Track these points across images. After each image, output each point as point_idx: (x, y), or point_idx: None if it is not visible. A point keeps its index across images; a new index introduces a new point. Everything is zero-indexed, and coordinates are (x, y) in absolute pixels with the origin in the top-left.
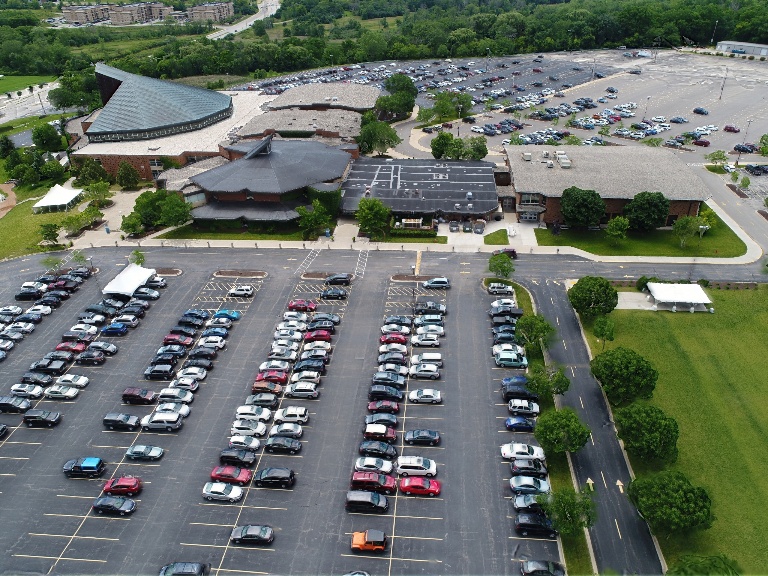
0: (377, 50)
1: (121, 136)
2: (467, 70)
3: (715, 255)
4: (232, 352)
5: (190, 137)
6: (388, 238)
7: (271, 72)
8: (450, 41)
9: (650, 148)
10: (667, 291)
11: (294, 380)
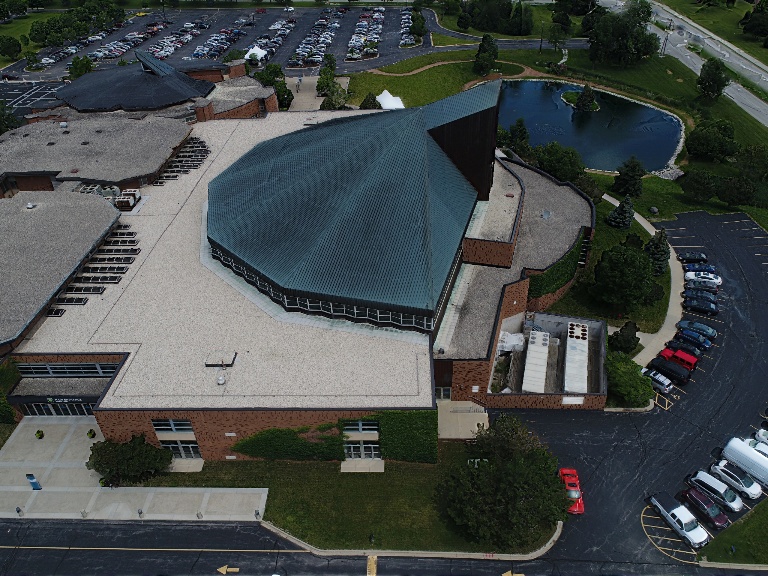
0: None
1: None
2: None
3: None
4: (194, 50)
5: None
6: None
7: None
8: None
9: None
10: None
11: (166, 43)
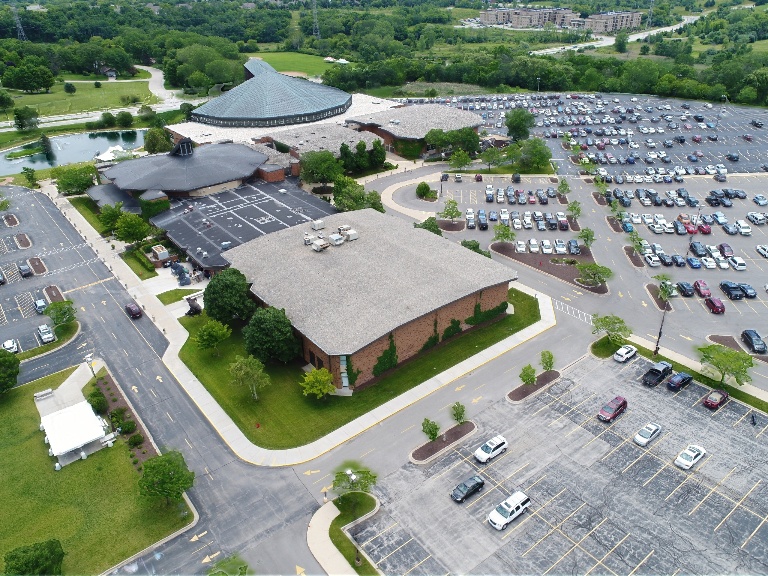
0: (645, 80)
1: (208, 120)
2: (699, 121)
3: (247, 427)
4: None
5: (247, 132)
6: (130, 256)
7: (517, 89)
8: (746, 80)
9: (496, 270)
10: (51, 414)
11: None
